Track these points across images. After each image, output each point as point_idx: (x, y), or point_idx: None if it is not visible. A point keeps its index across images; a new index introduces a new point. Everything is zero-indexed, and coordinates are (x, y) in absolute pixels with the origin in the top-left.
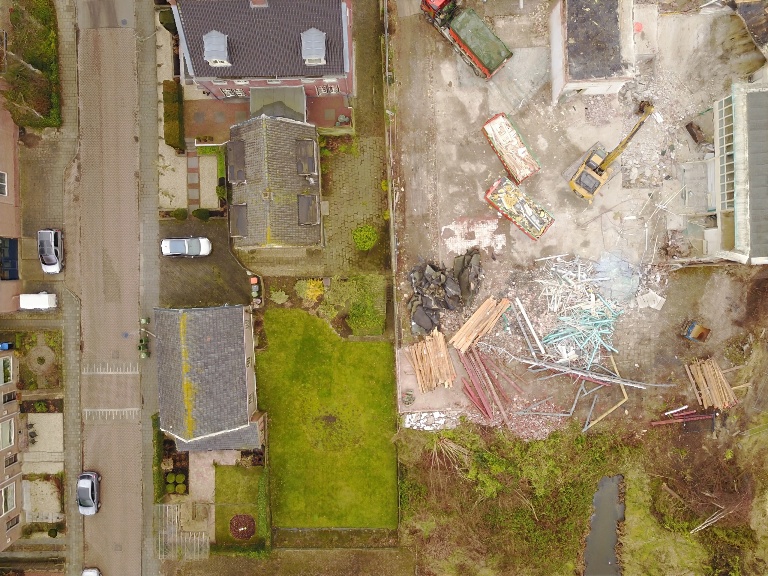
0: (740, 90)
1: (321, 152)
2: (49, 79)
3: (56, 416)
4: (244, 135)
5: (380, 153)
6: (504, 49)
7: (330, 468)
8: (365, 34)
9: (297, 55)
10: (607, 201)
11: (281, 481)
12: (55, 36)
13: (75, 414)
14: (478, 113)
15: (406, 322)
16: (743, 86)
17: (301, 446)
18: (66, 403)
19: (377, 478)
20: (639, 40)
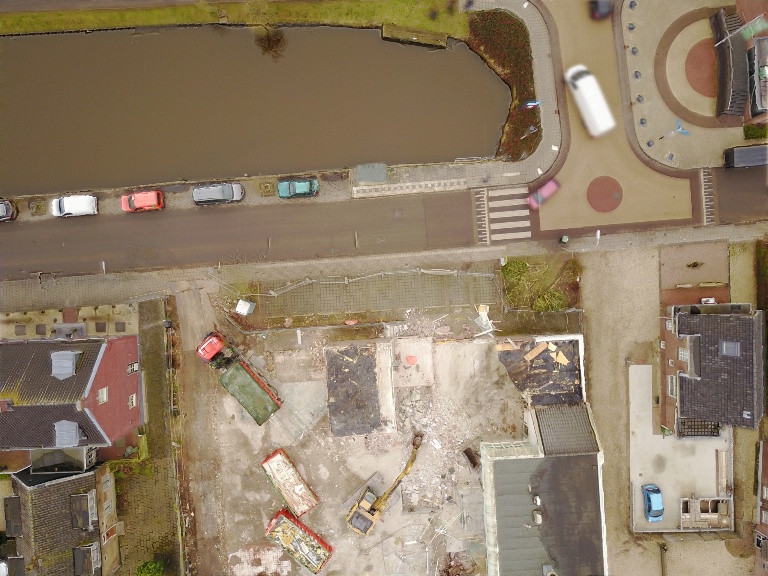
0: (487, 457)
1: (115, 475)
2: None
3: None
4: (19, 492)
5: None
6: (271, 403)
7: None
8: (154, 363)
9: None
10: (388, 527)
11: None
12: None
13: None
14: (261, 444)
15: None
16: (490, 453)
17: None
18: None
19: None
20: (414, 372)
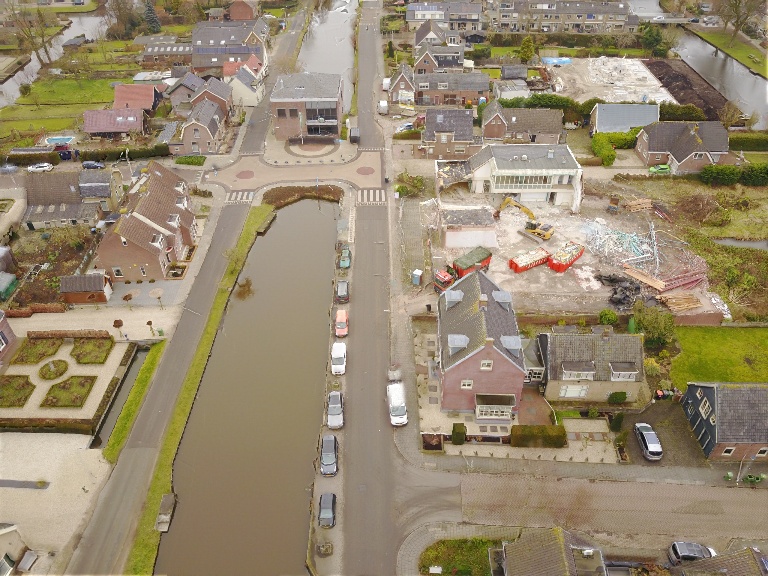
0: (497, 171)
1: None
2: None
3: None
4: (558, 361)
5: (538, 328)
6: (477, 249)
7: None
8: None
9: (504, 312)
10: None
11: None
12: None
13: None
14: (508, 275)
15: None
16: (495, 171)
17: None
18: None
19: None
20: None
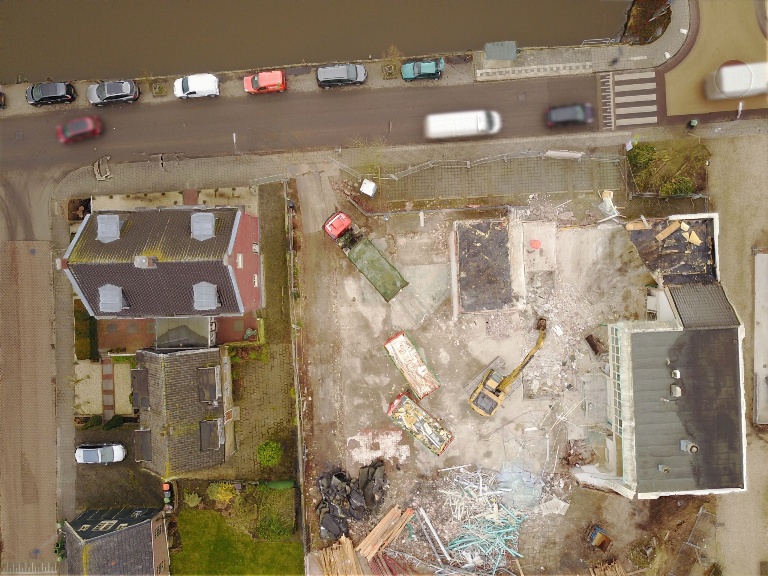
0: (624, 330)
1: (232, 360)
2: None
3: None
4: (147, 364)
5: (290, 359)
6: (399, 279)
7: None
8: (273, 247)
9: (192, 300)
10: (509, 413)
11: None
12: None
13: None
14: (381, 328)
15: (315, 527)
16: (627, 326)
17: None
18: None
19: None
20: (538, 257)
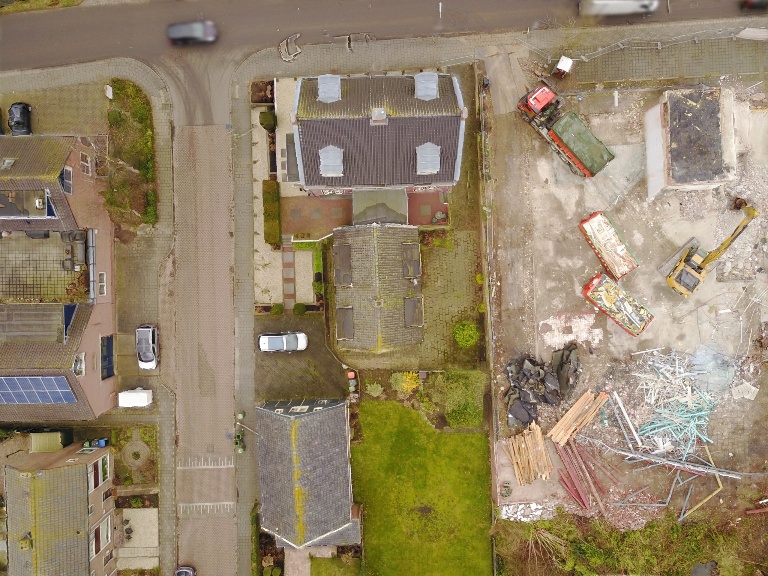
0: None
1: None
2: (146, 177)
3: (151, 511)
4: (350, 239)
5: (474, 246)
6: (606, 152)
7: (426, 559)
8: None
9: (409, 166)
10: (702, 295)
11: (377, 573)
12: (151, 134)
13: (170, 509)
14: (574, 209)
15: (503, 415)
16: None
17: (396, 537)
18: (161, 498)
19: (472, 568)
20: None
